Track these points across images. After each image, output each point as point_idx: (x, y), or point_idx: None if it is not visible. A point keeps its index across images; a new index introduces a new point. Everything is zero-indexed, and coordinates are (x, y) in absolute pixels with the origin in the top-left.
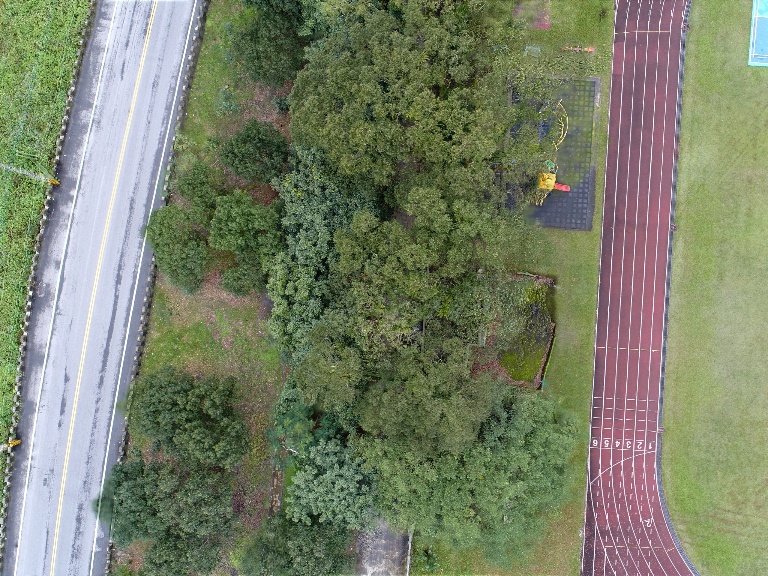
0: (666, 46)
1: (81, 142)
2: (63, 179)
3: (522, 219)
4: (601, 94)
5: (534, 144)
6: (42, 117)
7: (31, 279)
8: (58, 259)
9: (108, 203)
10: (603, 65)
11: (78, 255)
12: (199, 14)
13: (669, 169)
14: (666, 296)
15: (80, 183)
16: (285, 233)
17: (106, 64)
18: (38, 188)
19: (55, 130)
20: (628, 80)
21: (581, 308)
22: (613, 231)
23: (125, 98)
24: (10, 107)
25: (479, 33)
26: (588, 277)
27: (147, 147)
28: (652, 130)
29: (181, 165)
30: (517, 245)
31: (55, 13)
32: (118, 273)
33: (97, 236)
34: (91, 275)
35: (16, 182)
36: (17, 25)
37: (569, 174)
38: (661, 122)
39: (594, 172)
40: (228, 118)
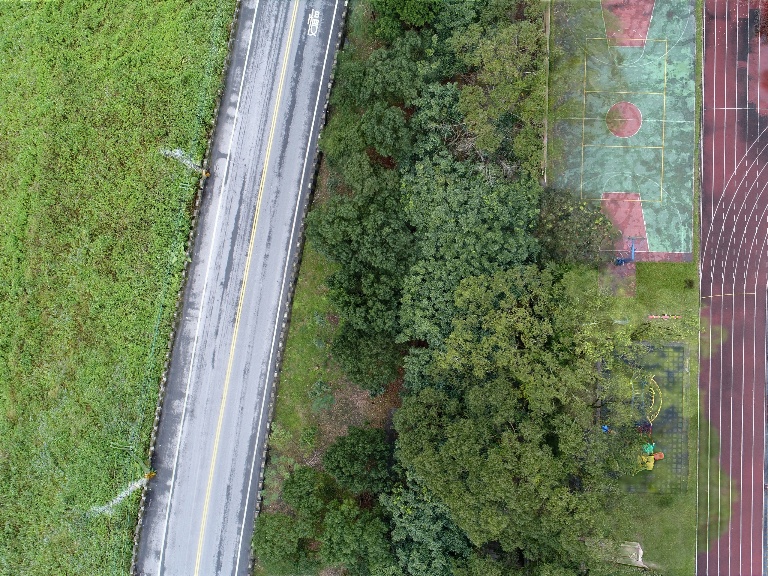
0: (752, 308)
1: (175, 432)
2: (159, 469)
3: (617, 487)
4: (690, 359)
5: (627, 415)
6: (135, 408)
7: (132, 572)
8: (158, 549)
9: (205, 491)
10: (690, 330)
11: (177, 544)
12: (287, 299)
13: (761, 430)
14: (763, 556)
15: (176, 473)
16: (395, 548)
17: (196, 353)
18: (134, 478)
19: (148, 420)
20: (716, 343)
21: (680, 572)
22: (708, 494)
23: (217, 386)
24: (102, 399)
25: (566, 304)
26: (685, 541)
27: (241, 433)
28: (742, 392)
29: (275, 449)
30: (613, 512)
31: (143, 304)
32: (218, 560)
33: (195, 524)
34: (191, 563)
35: (112, 473)
36: (106, 319)
37: (662, 440)
38: (750, 383)
39: (686, 437)
40: (319, 398)
